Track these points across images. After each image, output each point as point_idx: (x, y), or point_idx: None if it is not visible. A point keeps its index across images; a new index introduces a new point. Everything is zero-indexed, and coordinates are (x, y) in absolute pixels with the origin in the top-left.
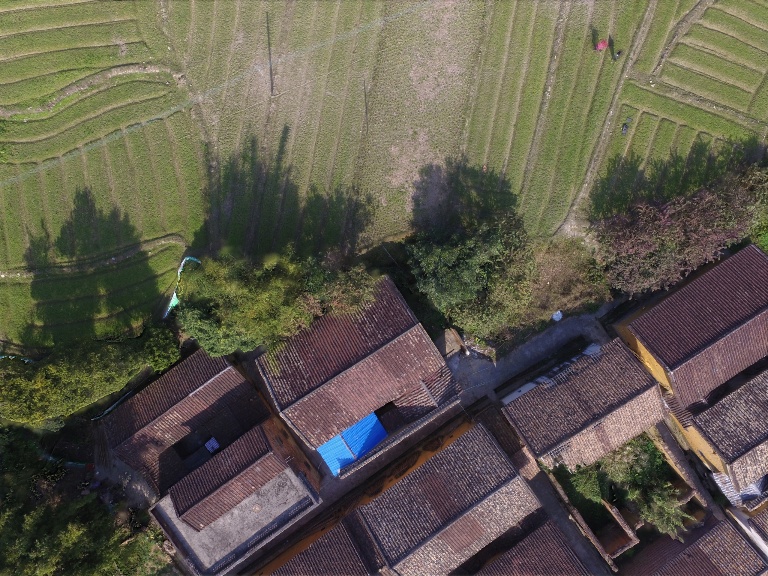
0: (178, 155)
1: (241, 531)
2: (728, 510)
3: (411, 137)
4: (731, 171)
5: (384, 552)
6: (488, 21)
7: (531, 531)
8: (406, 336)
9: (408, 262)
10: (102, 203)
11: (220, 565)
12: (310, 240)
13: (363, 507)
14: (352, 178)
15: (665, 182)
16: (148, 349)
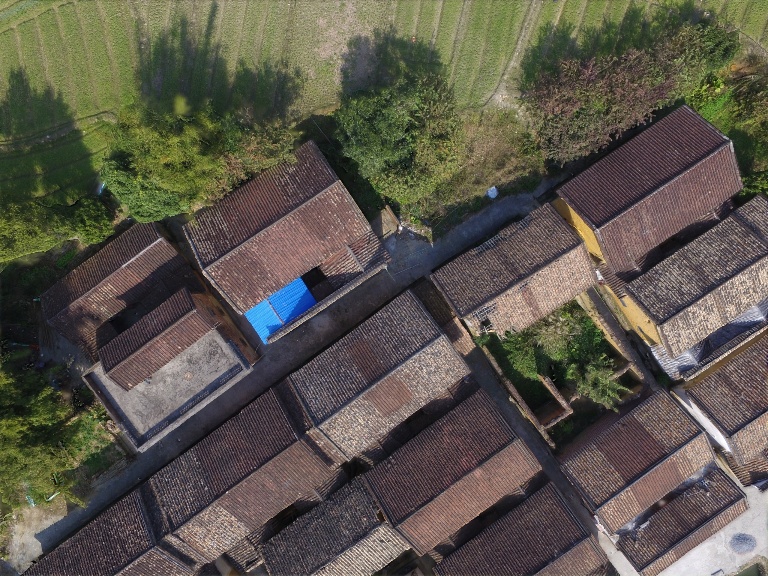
0: (109, 33)
1: (174, 398)
2: (671, 391)
3: (339, 9)
4: None
5: (310, 413)
6: None
7: (462, 400)
8: (327, 194)
9: (336, 131)
10: (36, 82)
11: (154, 432)
12: None
13: (293, 374)
14: (281, 52)
15: (598, 49)
16: (78, 218)
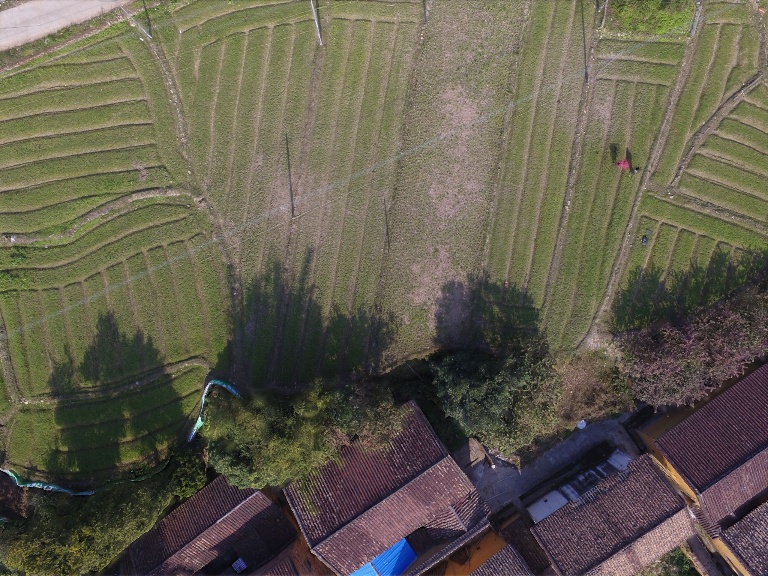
0: (200, 277)
1: None
2: None
3: (432, 254)
4: (751, 280)
5: None
6: (506, 137)
7: None
8: (435, 468)
9: (433, 382)
10: (125, 327)
11: None
12: (334, 360)
13: None
14: (374, 297)
15: (686, 293)
16: (175, 481)
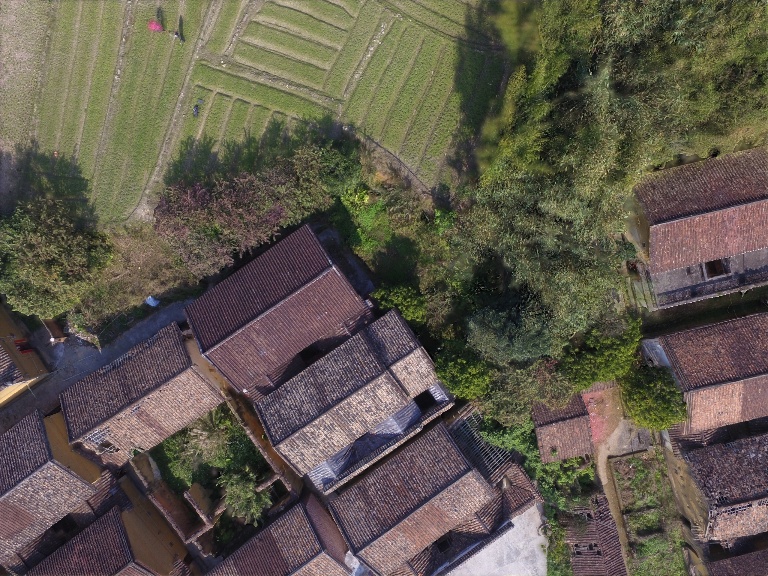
0: None
1: None
2: None
3: None
4: None
5: None
6: (57, 5)
7: (99, 517)
8: None
9: None
10: None
11: None
12: None
13: None
14: None
15: (239, 163)
16: None
